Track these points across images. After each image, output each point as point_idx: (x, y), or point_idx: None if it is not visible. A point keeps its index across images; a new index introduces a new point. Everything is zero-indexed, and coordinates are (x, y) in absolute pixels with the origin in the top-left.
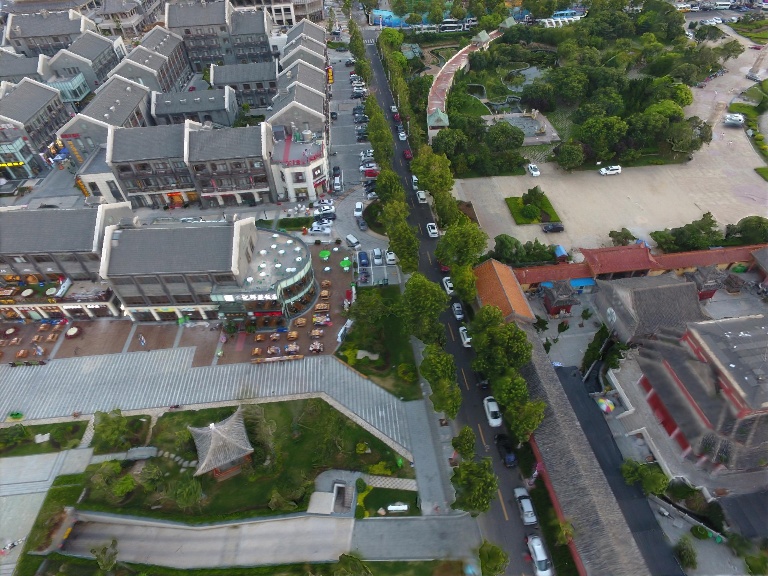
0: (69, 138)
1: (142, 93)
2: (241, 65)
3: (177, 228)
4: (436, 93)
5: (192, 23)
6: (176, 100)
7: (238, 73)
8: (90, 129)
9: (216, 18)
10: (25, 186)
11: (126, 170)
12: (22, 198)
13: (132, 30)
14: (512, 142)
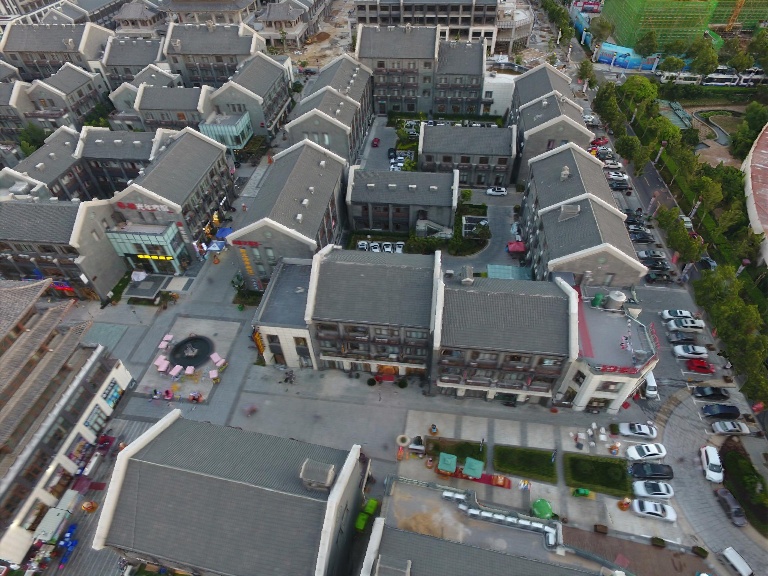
0: (243, 245)
1: (337, 168)
2: (462, 128)
3: None
4: (762, 208)
5: (390, 54)
6: (382, 183)
7: (457, 140)
8: (276, 239)
9: (422, 50)
10: (170, 292)
11: (328, 328)
12: (164, 312)
13: (294, 41)
14: None
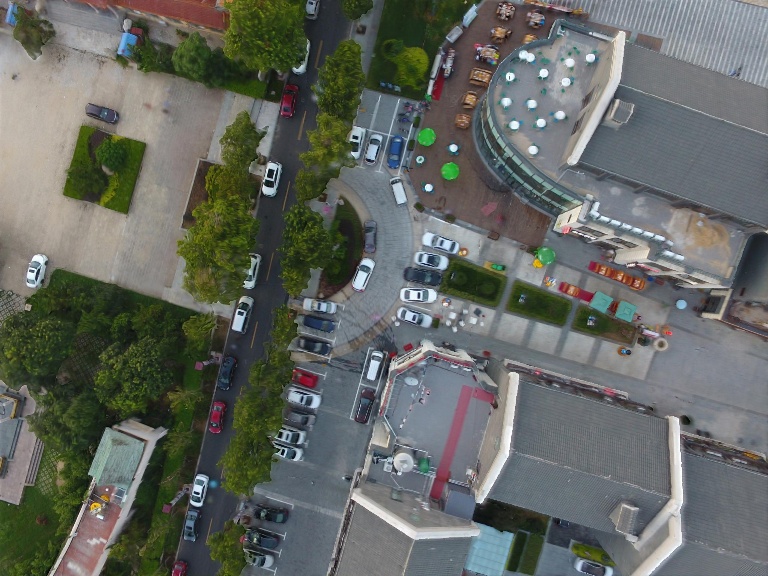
0: None
1: None
2: None
3: (716, 117)
4: None
5: None
6: None
7: None
8: None
9: None
10: None
11: None
12: None
13: None
14: (29, 319)
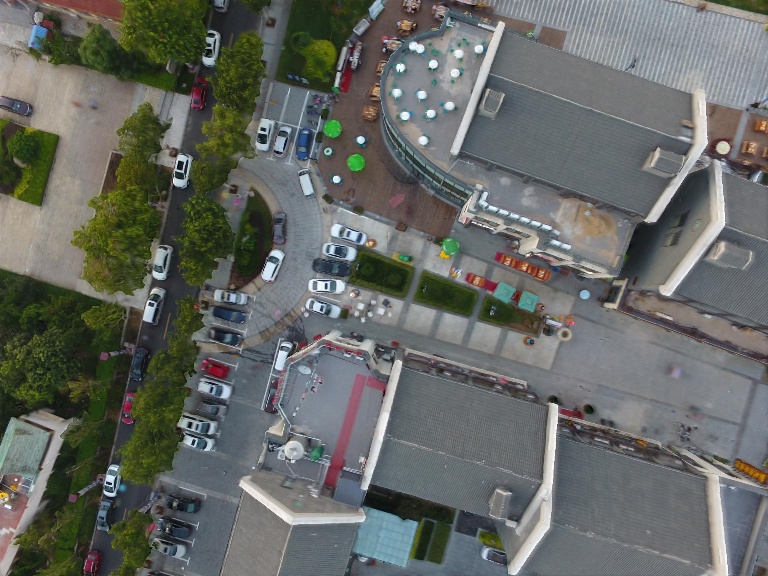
0: None
1: None
2: None
3: (585, 106)
4: None
5: None
6: None
7: None
8: None
9: None
10: None
11: None
12: None
13: None
14: None
